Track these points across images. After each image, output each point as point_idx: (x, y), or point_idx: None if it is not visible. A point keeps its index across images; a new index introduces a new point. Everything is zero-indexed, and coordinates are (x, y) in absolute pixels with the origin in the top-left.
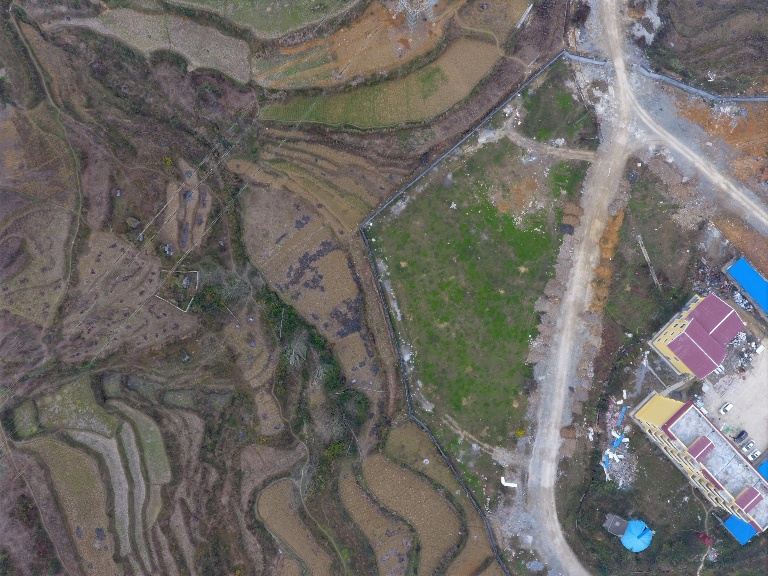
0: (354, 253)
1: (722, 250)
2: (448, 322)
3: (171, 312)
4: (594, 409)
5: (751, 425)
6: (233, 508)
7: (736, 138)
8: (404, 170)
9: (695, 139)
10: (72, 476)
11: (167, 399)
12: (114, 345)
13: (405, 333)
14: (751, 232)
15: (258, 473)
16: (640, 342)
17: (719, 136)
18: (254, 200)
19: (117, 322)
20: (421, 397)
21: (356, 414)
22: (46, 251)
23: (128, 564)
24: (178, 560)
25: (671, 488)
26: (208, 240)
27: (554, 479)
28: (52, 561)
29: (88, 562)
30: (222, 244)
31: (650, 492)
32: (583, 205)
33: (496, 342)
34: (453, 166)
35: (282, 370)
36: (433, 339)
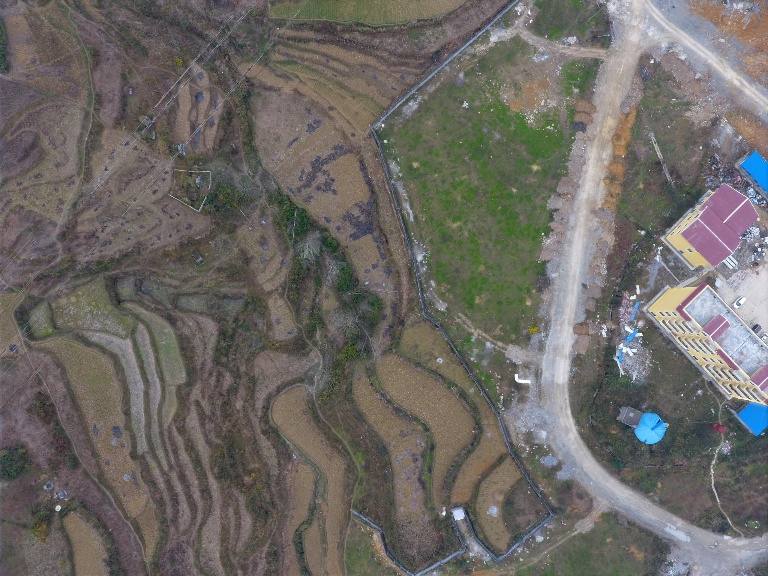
0: (366, 155)
1: (735, 146)
2: (461, 221)
3: (184, 212)
4: (607, 306)
5: (764, 319)
6: (247, 413)
7: (749, 34)
8: (416, 70)
9: (708, 36)
10: (88, 375)
11: (181, 304)
12: (128, 245)
13: (418, 233)
14: (764, 128)
15: (272, 379)
16: (653, 238)
17: (732, 32)
18: (265, 104)
19: (131, 221)
20: (434, 297)
21: (369, 316)
22: (60, 146)
23: (145, 462)
24: (194, 459)
25: (684, 382)
26: (220, 143)
27: (567, 375)
28: (70, 457)
29: (105, 459)
30: (234, 147)
31: (664, 386)
32: (595, 103)
33: (509, 240)
34: (465, 65)
35: (295, 274)
36: (446, 238)
